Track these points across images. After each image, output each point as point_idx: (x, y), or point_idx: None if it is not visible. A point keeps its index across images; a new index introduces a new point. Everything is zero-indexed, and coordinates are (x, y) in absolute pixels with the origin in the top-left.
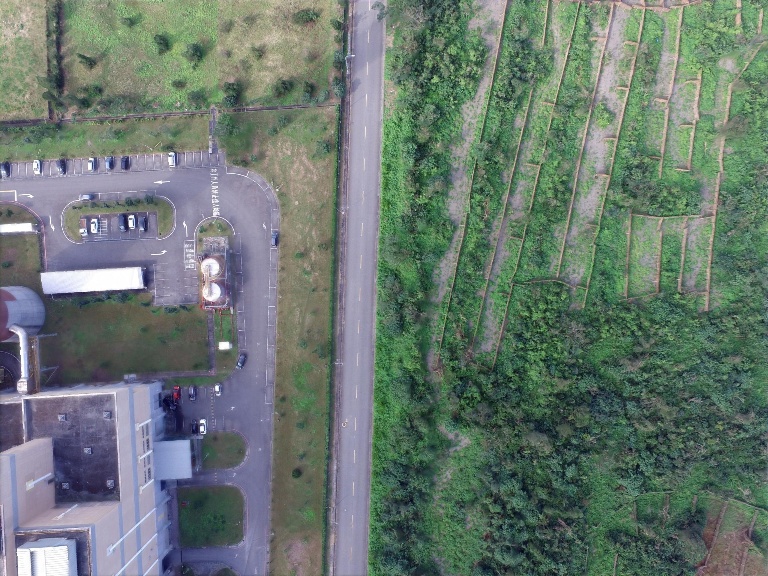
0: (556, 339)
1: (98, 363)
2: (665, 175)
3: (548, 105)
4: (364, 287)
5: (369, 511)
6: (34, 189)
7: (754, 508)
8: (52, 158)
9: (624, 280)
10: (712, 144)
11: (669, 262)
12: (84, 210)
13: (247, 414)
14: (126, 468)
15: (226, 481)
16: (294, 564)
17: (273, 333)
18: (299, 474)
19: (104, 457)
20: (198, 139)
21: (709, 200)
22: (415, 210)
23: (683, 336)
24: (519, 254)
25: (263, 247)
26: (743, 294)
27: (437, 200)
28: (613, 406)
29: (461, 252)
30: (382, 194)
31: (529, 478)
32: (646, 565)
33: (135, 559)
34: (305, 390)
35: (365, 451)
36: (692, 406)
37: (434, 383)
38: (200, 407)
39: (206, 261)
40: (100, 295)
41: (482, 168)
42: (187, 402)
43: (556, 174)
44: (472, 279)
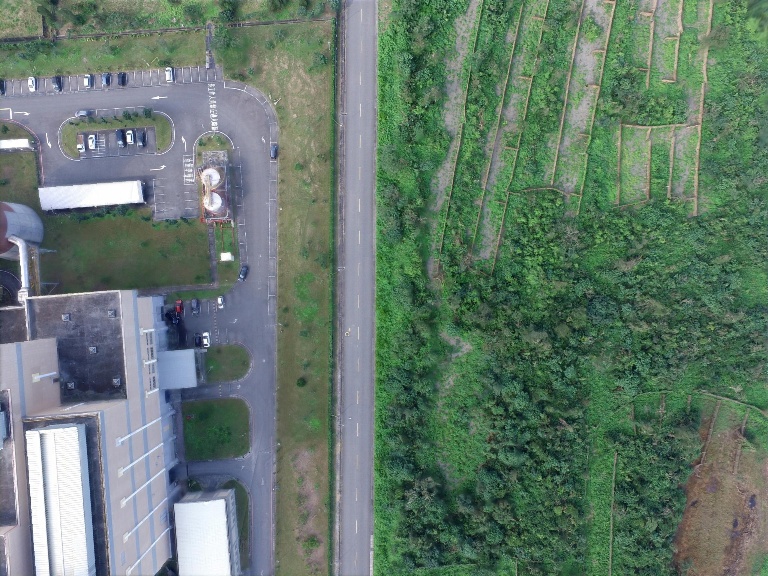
0: (552, 244)
1: (99, 279)
2: (652, 86)
3: (538, 20)
4: (363, 198)
5: (374, 419)
6: (29, 107)
7: (746, 406)
8: (47, 75)
9: (616, 189)
10: (696, 56)
11: (658, 170)
12: (81, 127)
13: (250, 326)
14: (132, 368)
15: (231, 393)
16: (301, 473)
17: (274, 245)
18: (304, 383)
19: (109, 356)
20: (195, 54)
21: (695, 110)
22: (412, 120)
23: (674, 240)
24: (514, 163)
25: (262, 160)
26: (729, 198)
27: (433, 111)
28: (609, 308)
29: (458, 161)
30: (379, 106)
31: (530, 380)
32: (645, 462)
33: (143, 460)
34: (308, 300)
35: (368, 360)
36: (684, 307)
37: (435, 290)
38: (203, 320)
39: (206, 171)
40: (99, 211)
41: (476, 79)
42: (190, 316)
43: (548, 85)
44: (469, 187)
